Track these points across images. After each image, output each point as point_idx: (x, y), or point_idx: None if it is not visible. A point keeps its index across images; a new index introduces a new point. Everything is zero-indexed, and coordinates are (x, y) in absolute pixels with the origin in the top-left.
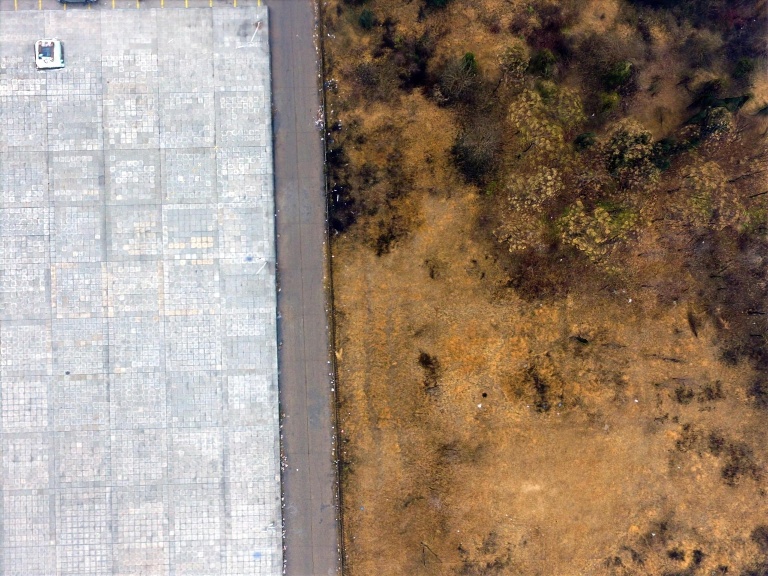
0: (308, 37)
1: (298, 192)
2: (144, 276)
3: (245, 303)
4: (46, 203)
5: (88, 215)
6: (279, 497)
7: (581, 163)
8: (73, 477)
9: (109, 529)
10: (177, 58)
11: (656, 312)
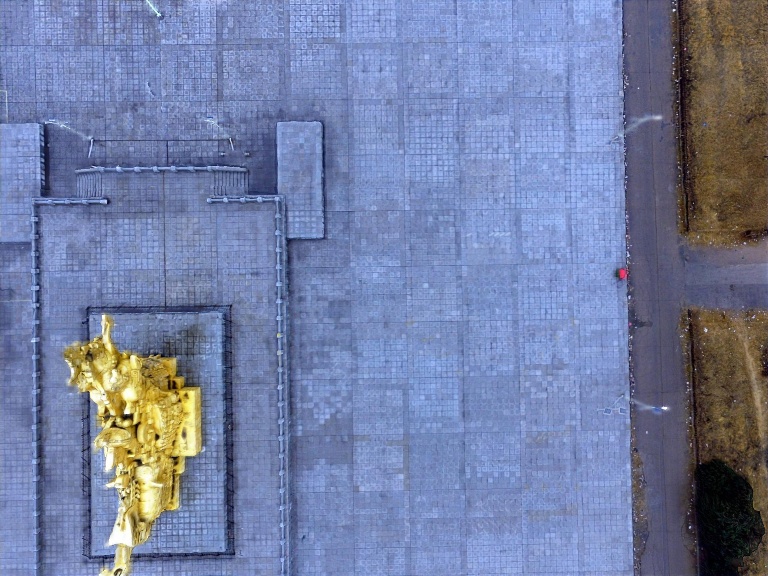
0: None
1: None
2: None
3: None
4: None
5: None
6: (622, 113)
7: None
8: (421, 88)
9: (456, 140)
10: None
11: None
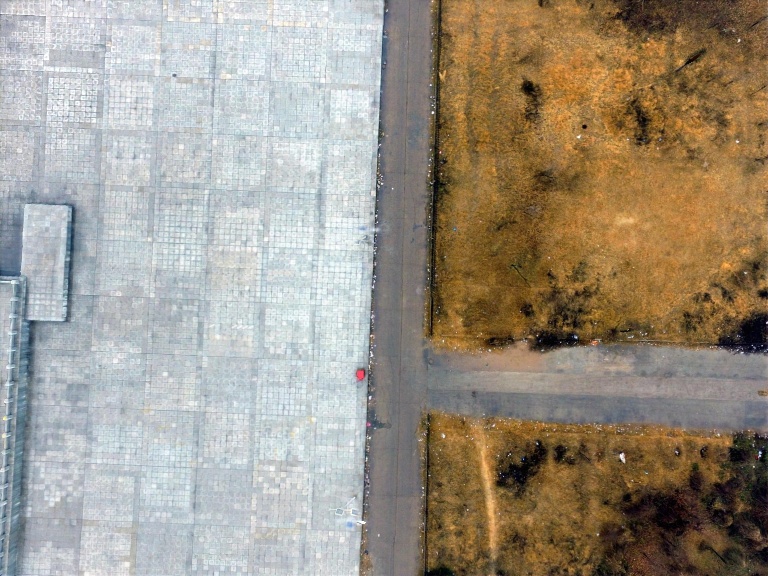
0: None
1: None
2: None
3: (353, 19)
4: None
5: None
6: (373, 212)
7: None
8: (173, 177)
9: (205, 230)
10: None
11: (765, 53)
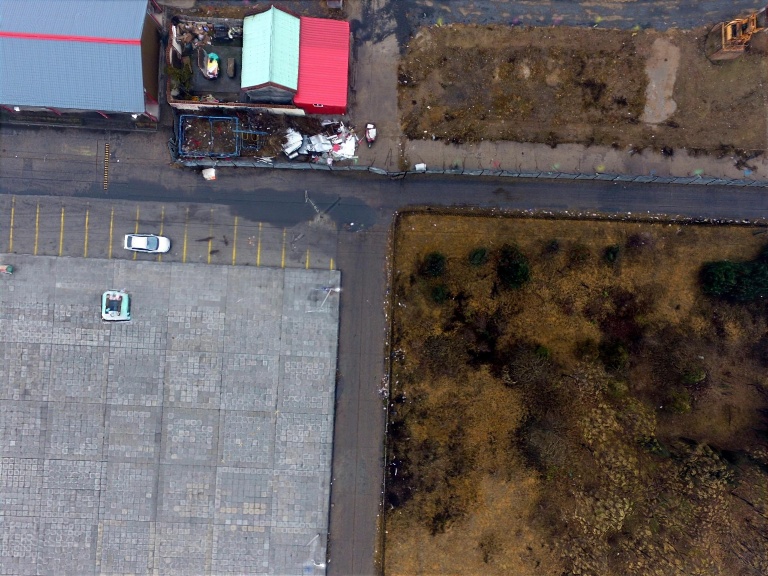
0: (378, 303)
1: (356, 461)
2: (193, 539)
3: (293, 575)
4: (99, 457)
5: (141, 472)
6: None
7: (652, 489)
8: None
9: None
10: (245, 318)
11: None
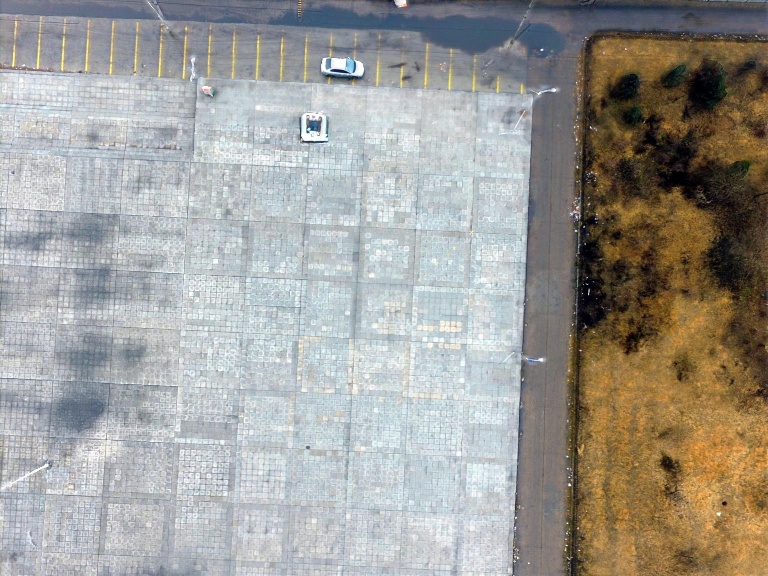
0: (569, 128)
1: (548, 282)
2: (391, 356)
3: (489, 391)
4: (299, 275)
5: (340, 290)
6: None
7: None
8: (306, 553)
9: None
10: (439, 140)
11: None
